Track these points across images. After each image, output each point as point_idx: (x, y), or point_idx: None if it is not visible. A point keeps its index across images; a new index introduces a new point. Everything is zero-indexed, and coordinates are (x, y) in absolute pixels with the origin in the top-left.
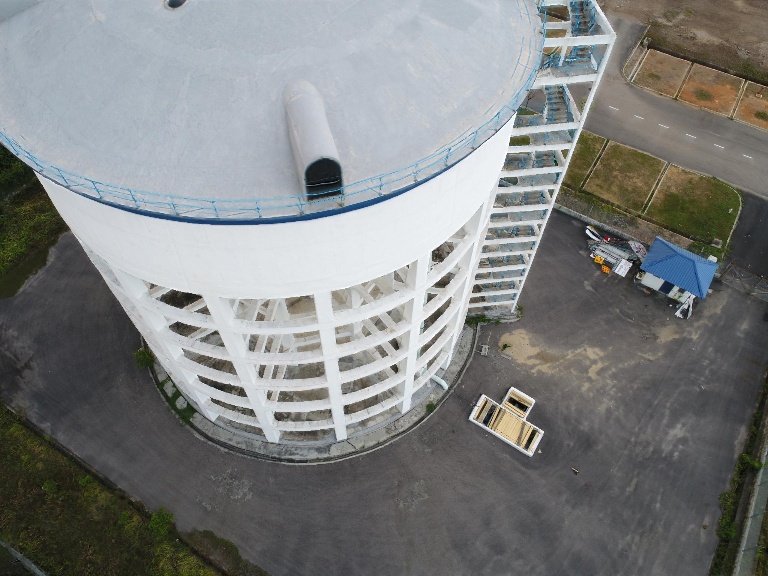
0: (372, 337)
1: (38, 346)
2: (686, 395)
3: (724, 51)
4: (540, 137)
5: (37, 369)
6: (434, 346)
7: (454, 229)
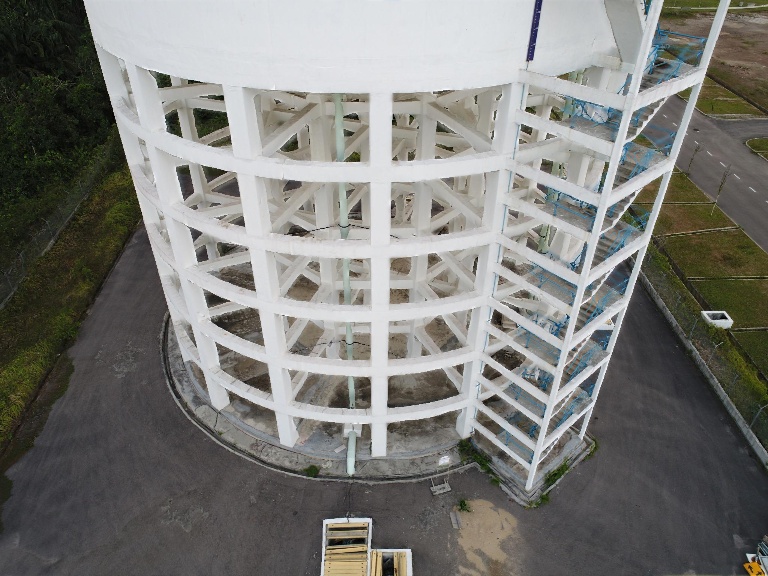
0: (207, 217)
1: None
2: None
3: None
4: (580, 122)
5: None
6: (327, 360)
7: (286, 79)
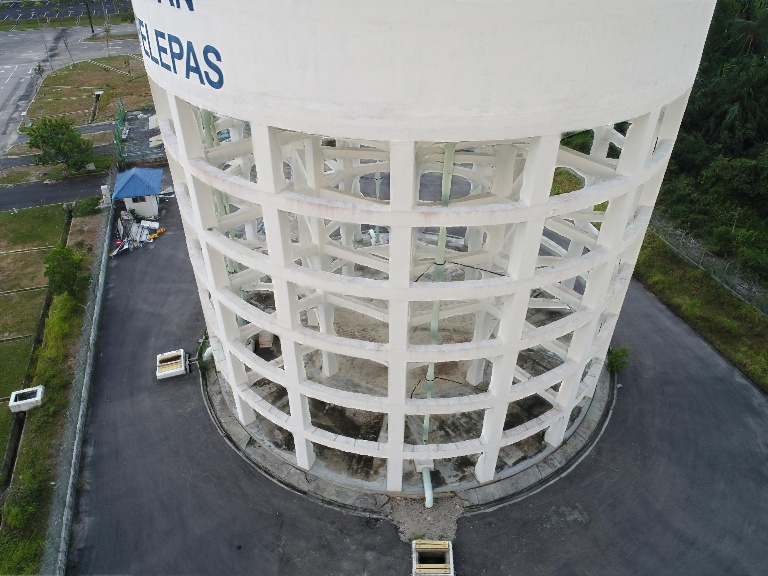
0: None
1: (761, 469)
2: None
3: None
4: None
5: (759, 441)
6: None
7: None
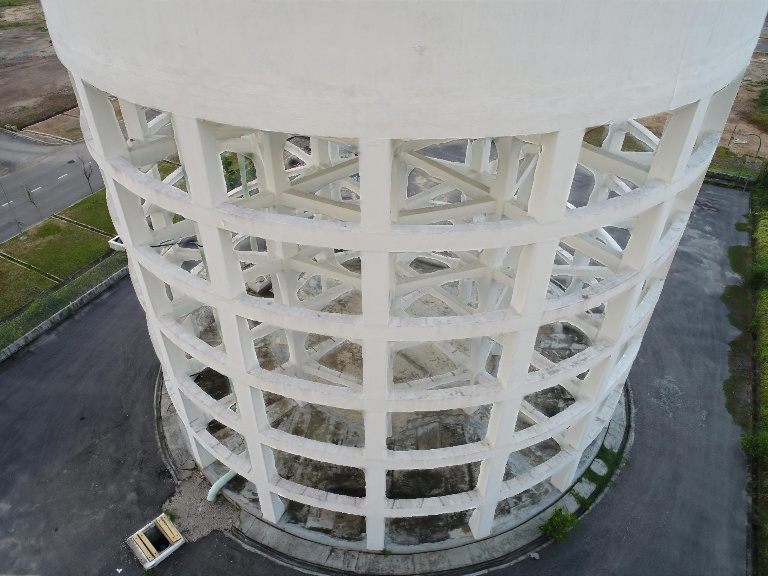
0: None
1: None
2: (447, 150)
3: (57, 98)
4: None
5: None
6: None
7: None
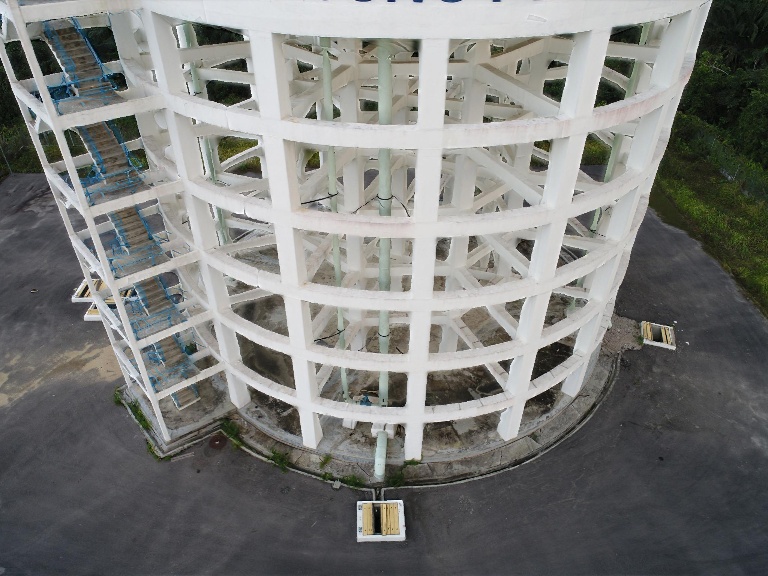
0: None
1: None
2: None
3: None
4: (54, 24)
5: None
6: None
7: None
